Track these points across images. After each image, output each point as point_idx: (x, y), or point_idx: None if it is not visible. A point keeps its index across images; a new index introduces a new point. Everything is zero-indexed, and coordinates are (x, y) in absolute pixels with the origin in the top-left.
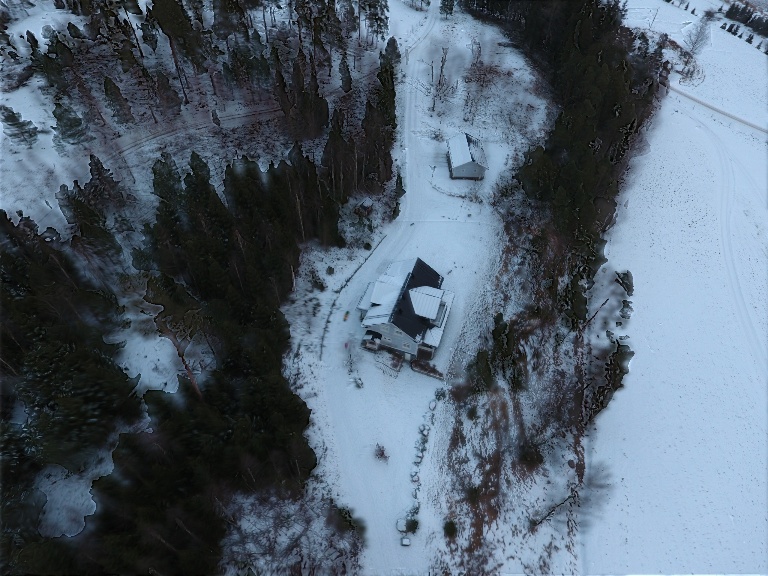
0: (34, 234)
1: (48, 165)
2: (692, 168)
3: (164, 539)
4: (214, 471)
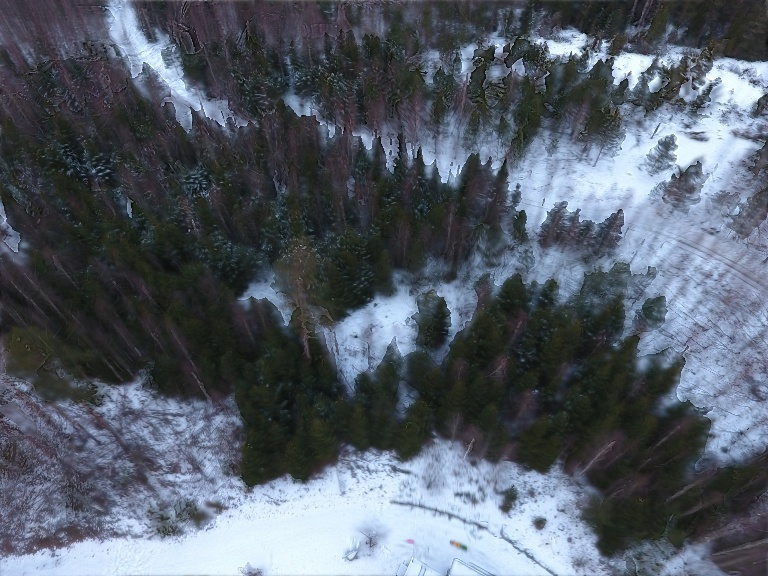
0: (512, 206)
1: (631, 193)
2: None
3: (186, 345)
4: (234, 376)
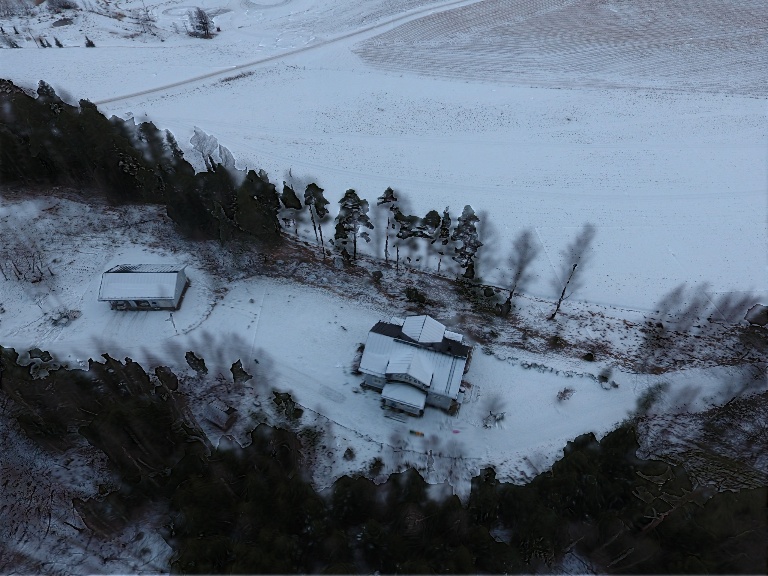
0: None
1: None
2: (182, 144)
3: None
4: None
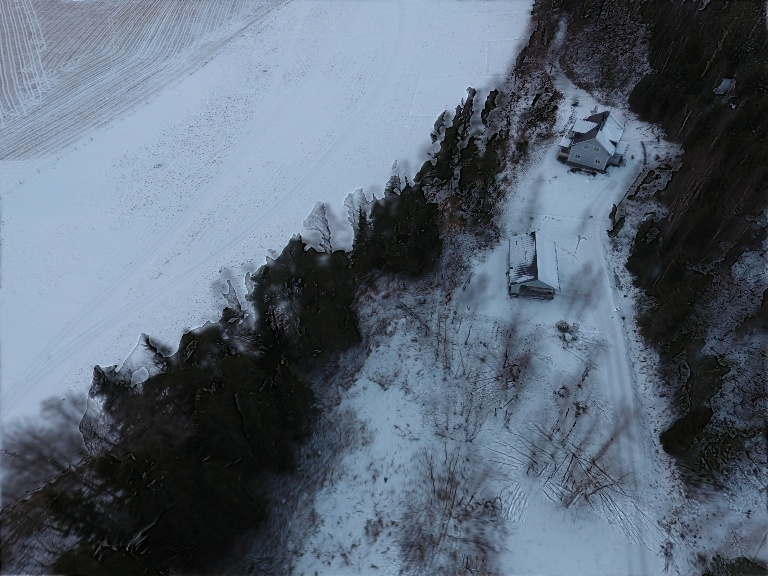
0: None
1: None
2: None
3: None
4: None
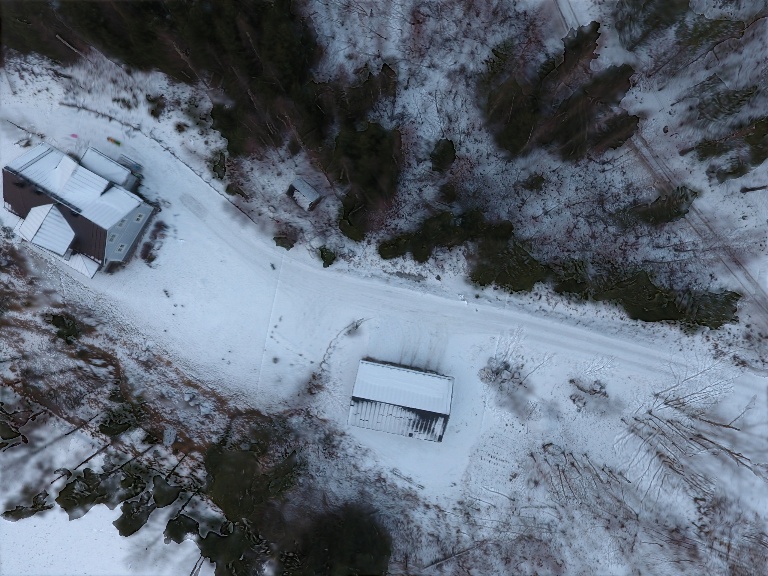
0: None
1: None
2: None
3: None
4: None
